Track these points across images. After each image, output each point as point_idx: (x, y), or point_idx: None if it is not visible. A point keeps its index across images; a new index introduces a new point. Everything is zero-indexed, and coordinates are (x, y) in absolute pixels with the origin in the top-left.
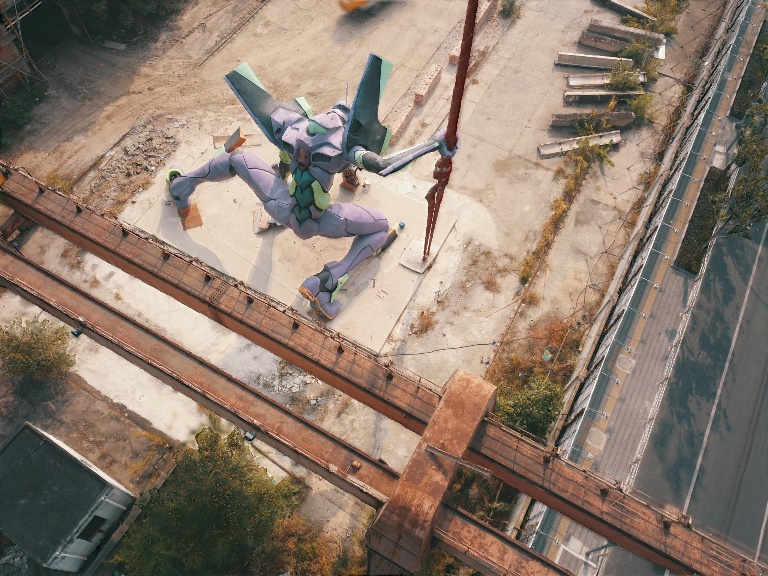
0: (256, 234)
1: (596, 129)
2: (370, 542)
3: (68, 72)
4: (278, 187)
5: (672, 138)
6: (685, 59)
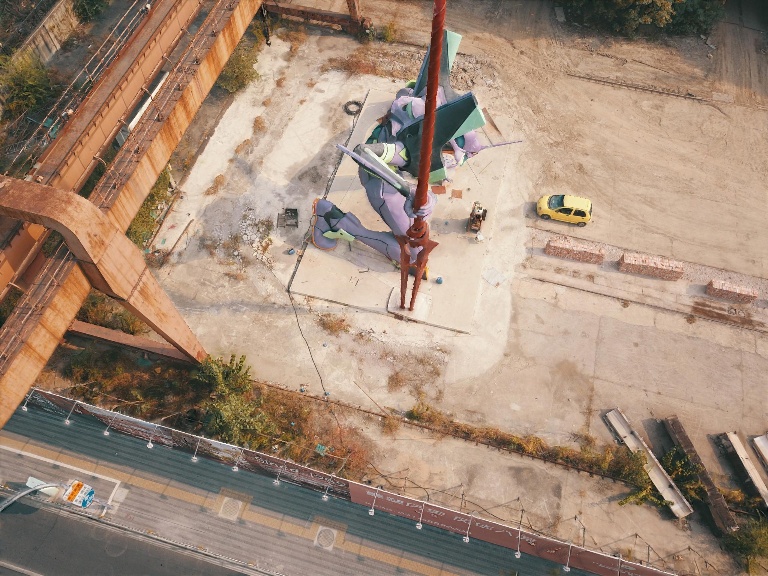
0: None
1: (684, 480)
2: None
3: None
4: None
5: None
6: None
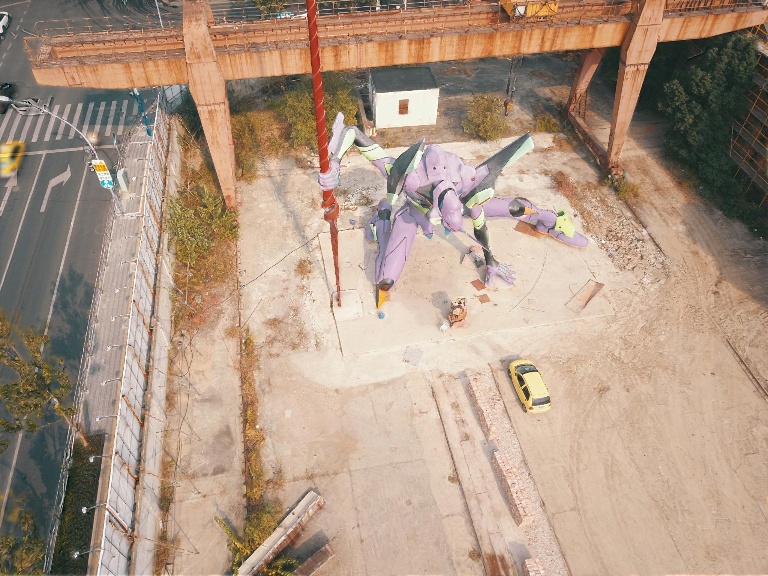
0: None
1: None
2: None
3: None
4: None
5: None
6: None
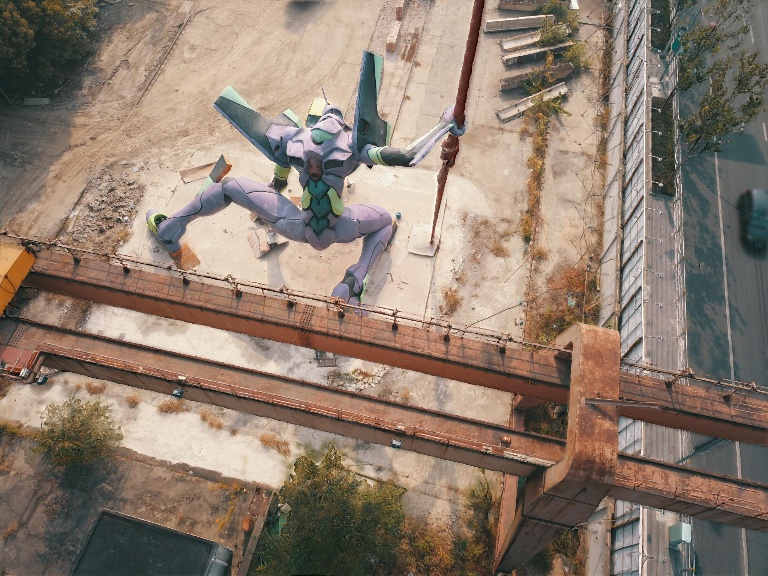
0: (259, 259)
1: (543, 85)
2: (534, 509)
3: None
4: (283, 205)
5: (613, 79)
6: (599, 5)
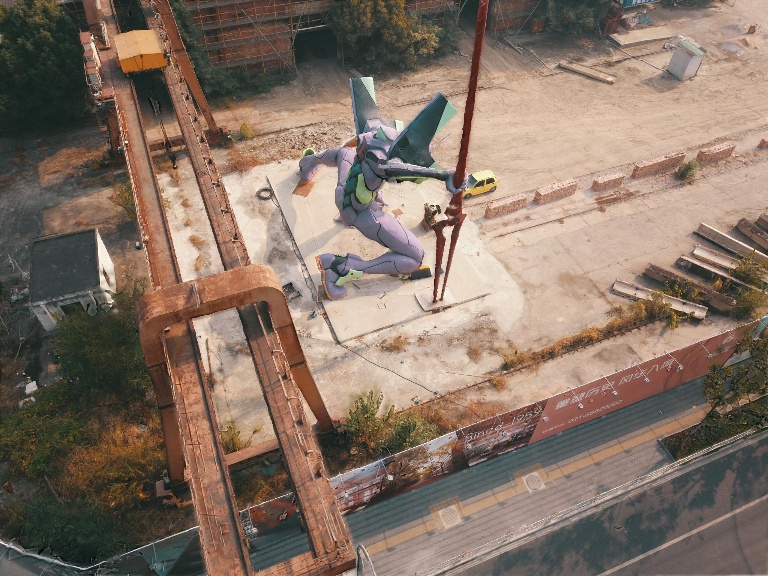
0: (334, 220)
1: (686, 296)
2: None
3: (314, 76)
4: None
5: None
6: None
